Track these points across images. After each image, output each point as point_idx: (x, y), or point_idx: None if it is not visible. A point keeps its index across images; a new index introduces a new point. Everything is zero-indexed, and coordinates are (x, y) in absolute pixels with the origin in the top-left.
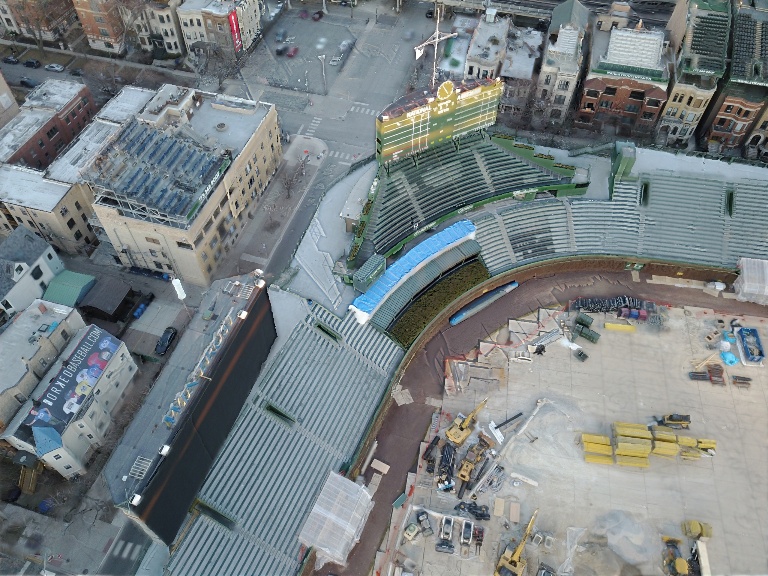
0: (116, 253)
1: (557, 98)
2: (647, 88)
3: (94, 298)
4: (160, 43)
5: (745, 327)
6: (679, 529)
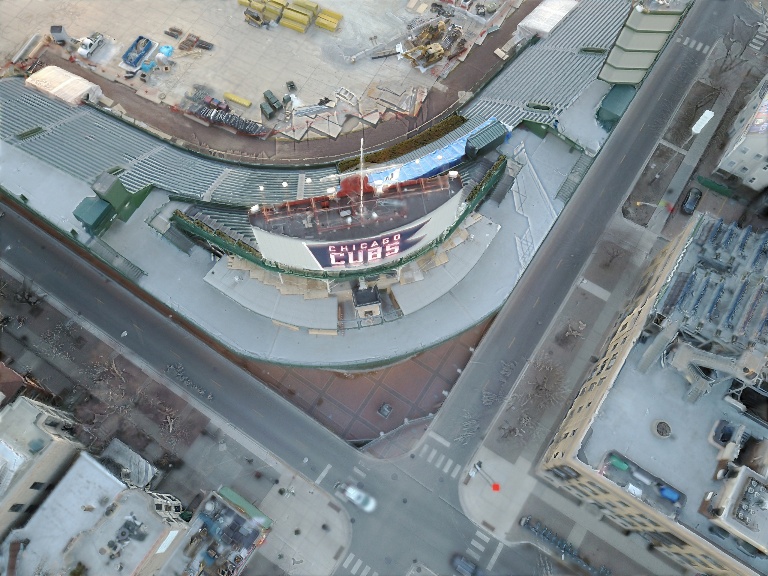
0: None
1: None
2: None
3: None
4: None
5: (124, 70)
6: None
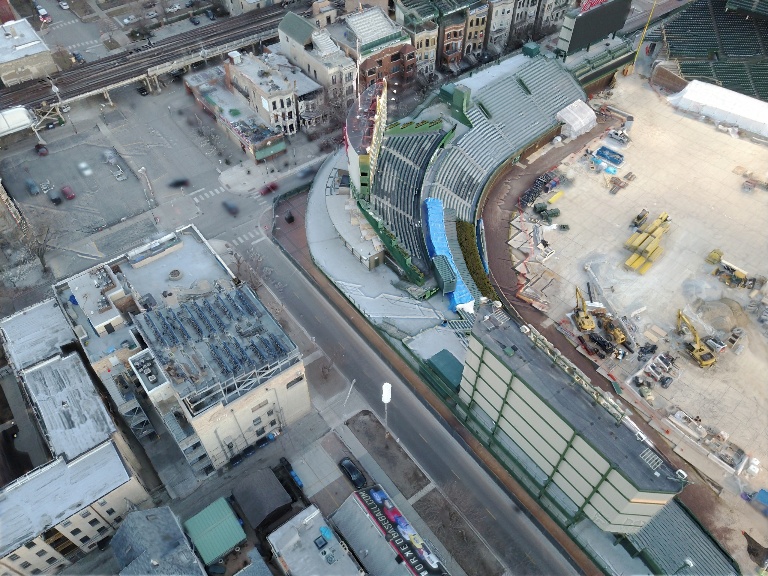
0: (208, 462)
1: (347, 90)
2: (400, 48)
3: (264, 504)
4: None
5: (595, 150)
6: (709, 264)
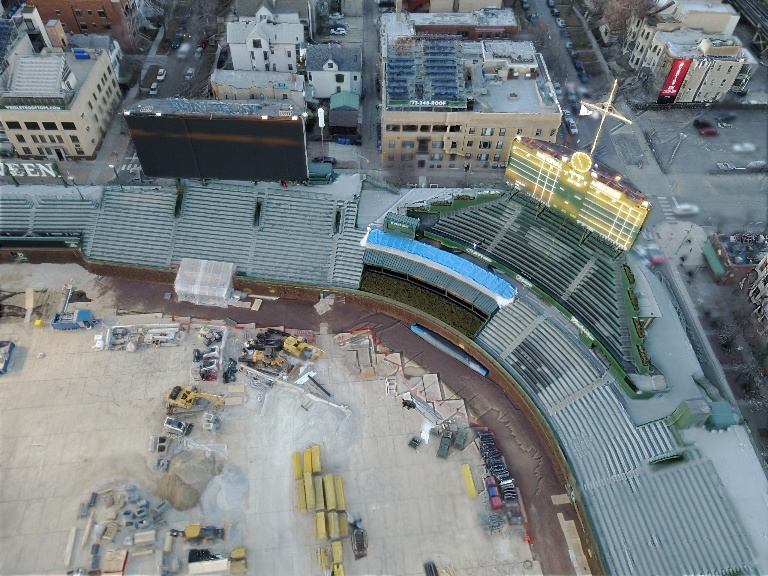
0: None
1: None
2: None
3: None
4: (630, 52)
5: None
6: (239, 544)
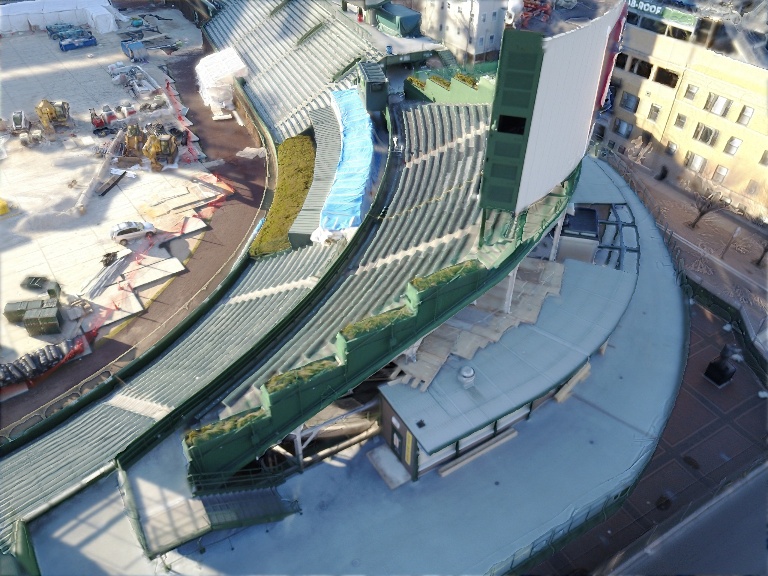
0: None
1: None
2: None
3: None
4: None
5: None
6: None
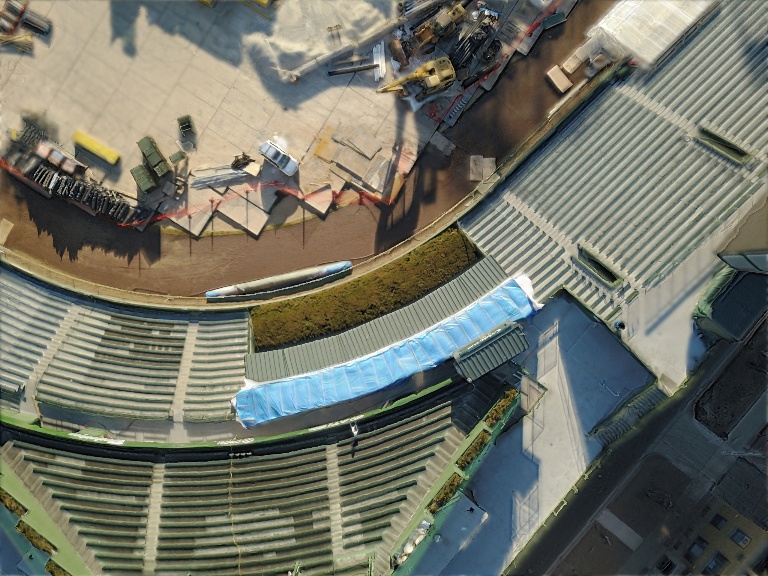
0: None
1: None
2: None
3: None
4: None
5: None
6: None
